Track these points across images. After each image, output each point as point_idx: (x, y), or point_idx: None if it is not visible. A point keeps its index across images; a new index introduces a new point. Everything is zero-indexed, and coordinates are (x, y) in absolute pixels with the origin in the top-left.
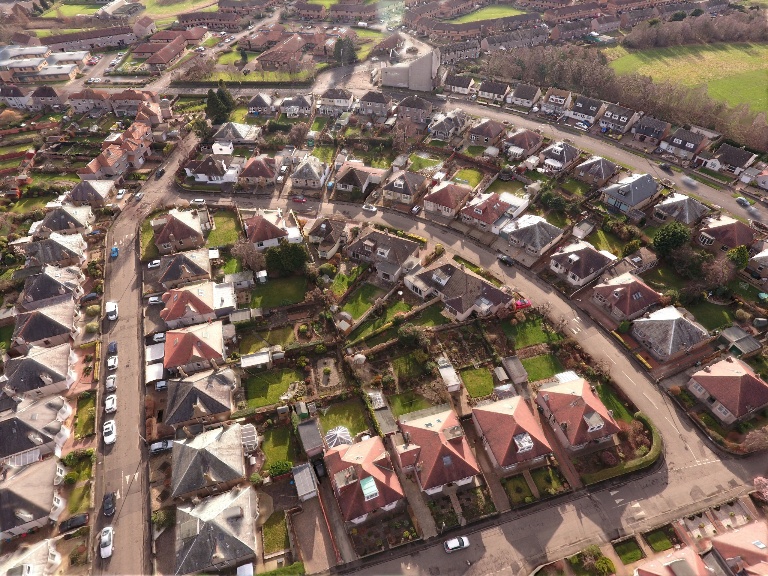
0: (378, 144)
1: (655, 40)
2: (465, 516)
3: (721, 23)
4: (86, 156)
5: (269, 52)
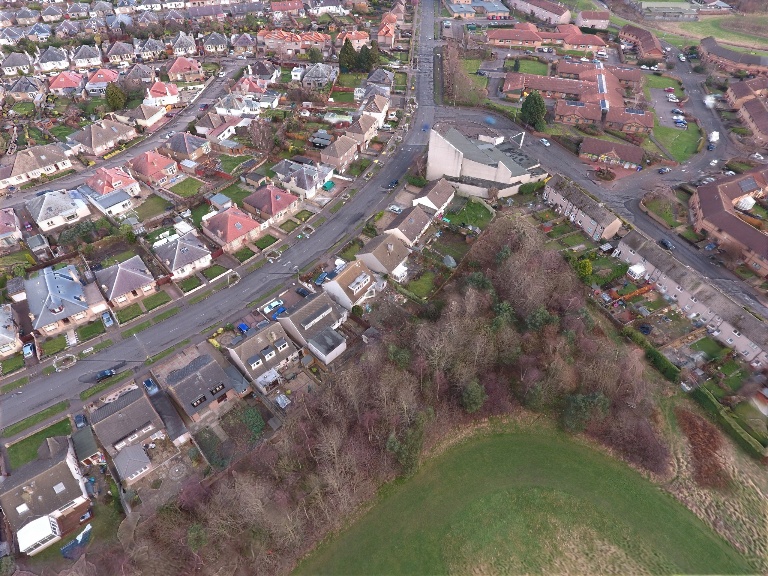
0: None
1: None
2: None
3: None
4: None
5: None
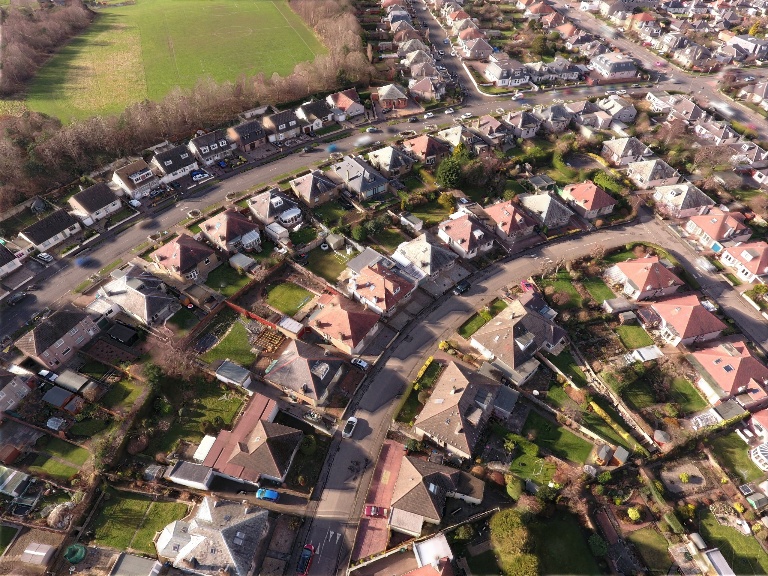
0: (147, 408)
1: (19, 74)
2: (766, 363)
3: (28, 30)
4: None
5: None
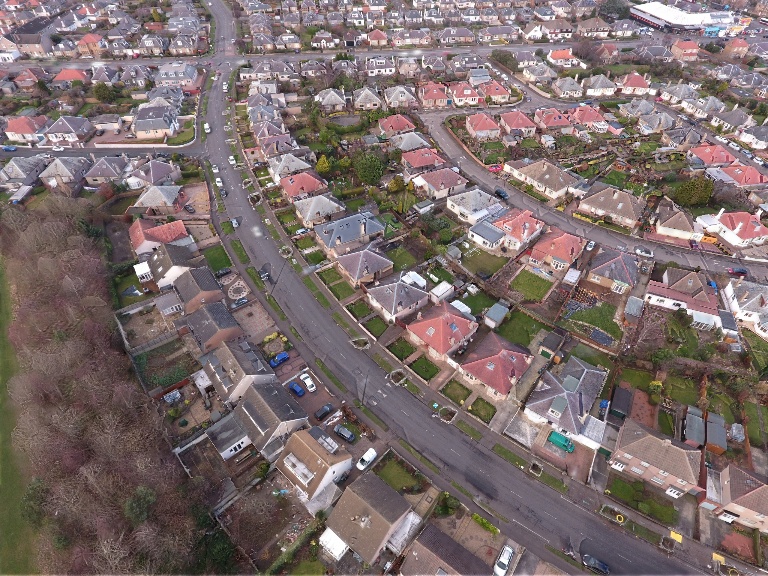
0: None
1: None
2: None
3: None
4: None
5: None
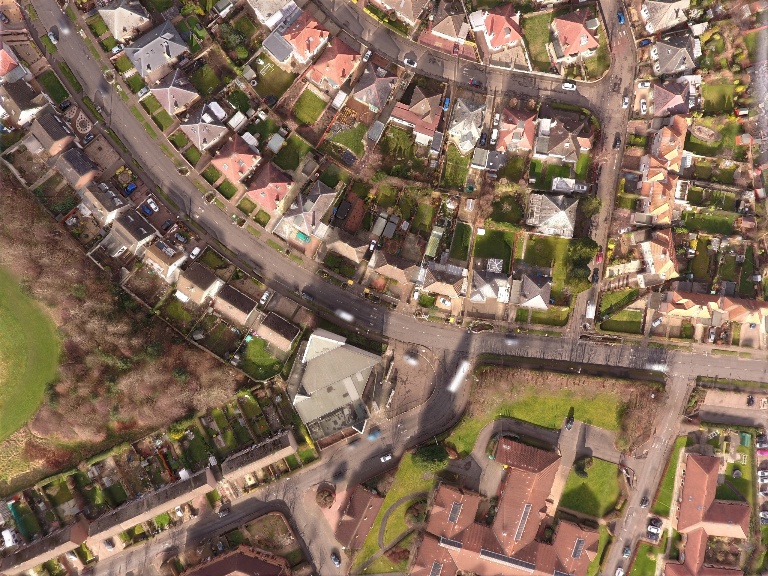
0: None
1: None
2: None
3: None
4: (702, 182)
5: (545, 471)
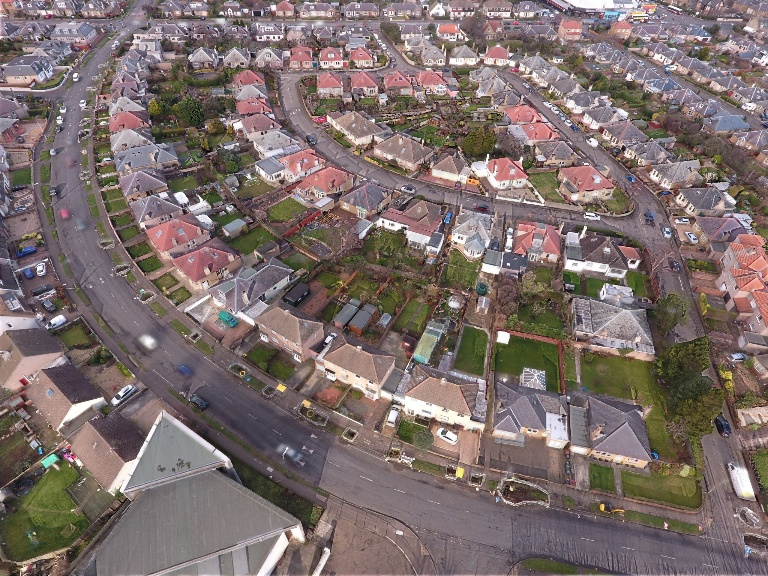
0: None
1: None
2: None
3: None
4: None
5: None
